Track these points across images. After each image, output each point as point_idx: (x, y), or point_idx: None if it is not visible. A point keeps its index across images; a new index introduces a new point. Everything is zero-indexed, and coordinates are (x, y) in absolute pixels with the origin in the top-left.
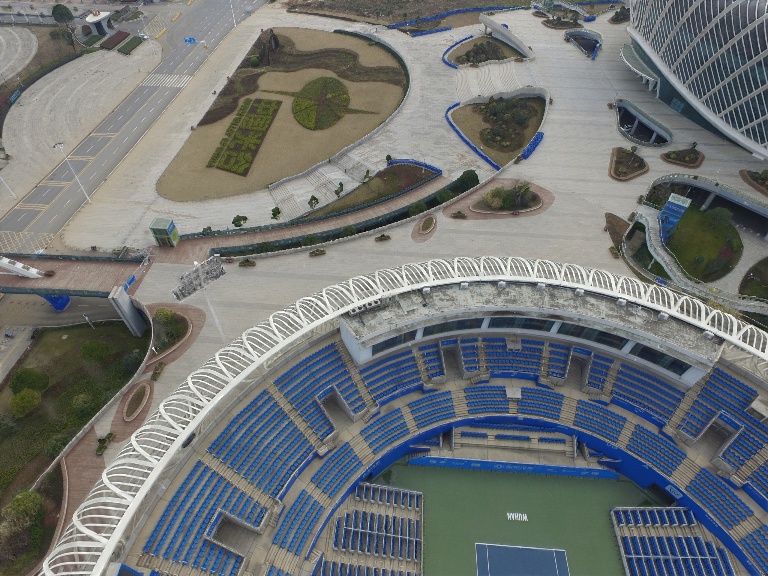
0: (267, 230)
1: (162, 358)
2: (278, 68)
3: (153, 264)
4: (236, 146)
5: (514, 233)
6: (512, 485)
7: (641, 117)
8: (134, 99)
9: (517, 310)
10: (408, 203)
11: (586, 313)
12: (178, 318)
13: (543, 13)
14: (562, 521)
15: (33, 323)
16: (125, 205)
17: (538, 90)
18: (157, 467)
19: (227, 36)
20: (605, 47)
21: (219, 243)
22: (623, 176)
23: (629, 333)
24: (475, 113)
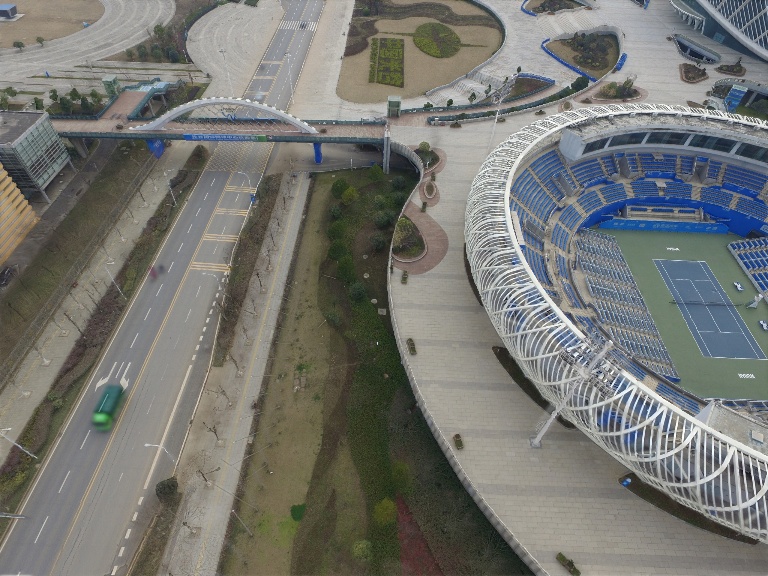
0: (455, 110)
1: (431, 171)
2: (387, 17)
3: (391, 126)
4: (385, 69)
5: None
6: (665, 237)
7: (693, 46)
8: (280, 38)
9: (667, 128)
10: None
11: (710, 128)
12: (431, 151)
13: None
14: (699, 251)
15: (304, 170)
16: (321, 106)
17: (611, 28)
18: (508, 181)
19: None
20: (651, 0)
21: (428, 116)
22: (692, 80)
23: (738, 137)
24: (564, 45)
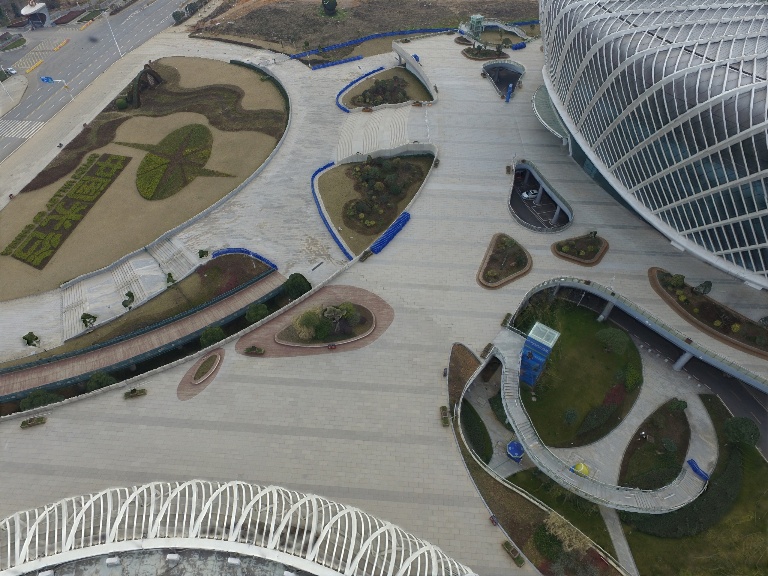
0: None
1: None
2: (147, 111)
3: None
4: (50, 223)
5: (319, 381)
6: None
7: (543, 185)
8: None
9: None
10: (212, 320)
11: None
12: None
13: (466, 40)
14: None
15: None
16: None
17: (427, 147)
18: None
19: (108, 69)
20: (527, 84)
21: None
22: (492, 282)
23: None
24: (348, 177)
